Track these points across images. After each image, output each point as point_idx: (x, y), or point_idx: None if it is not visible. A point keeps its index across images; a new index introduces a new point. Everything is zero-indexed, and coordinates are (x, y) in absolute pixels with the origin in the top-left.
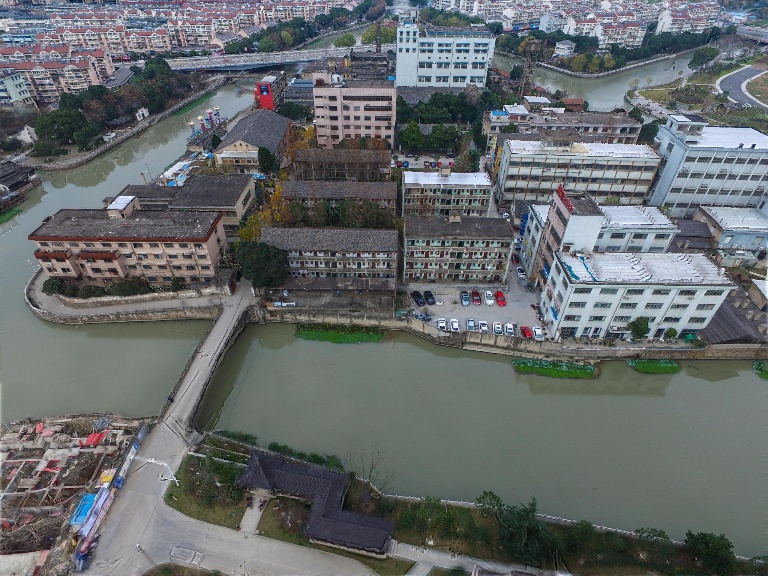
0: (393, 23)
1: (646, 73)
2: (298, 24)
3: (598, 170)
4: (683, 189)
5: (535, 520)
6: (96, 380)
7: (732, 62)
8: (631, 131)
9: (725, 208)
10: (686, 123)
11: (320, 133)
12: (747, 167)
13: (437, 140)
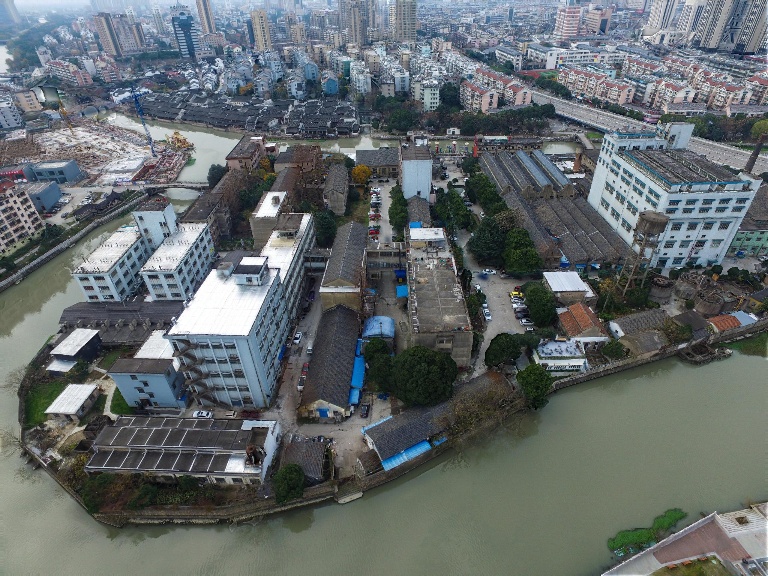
0: None
1: None
2: None
3: None
4: None
5: (50, 232)
6: (193, 178)
7: None
8: None
9: None
10: None
11: None
12: None
13: (390, 216)
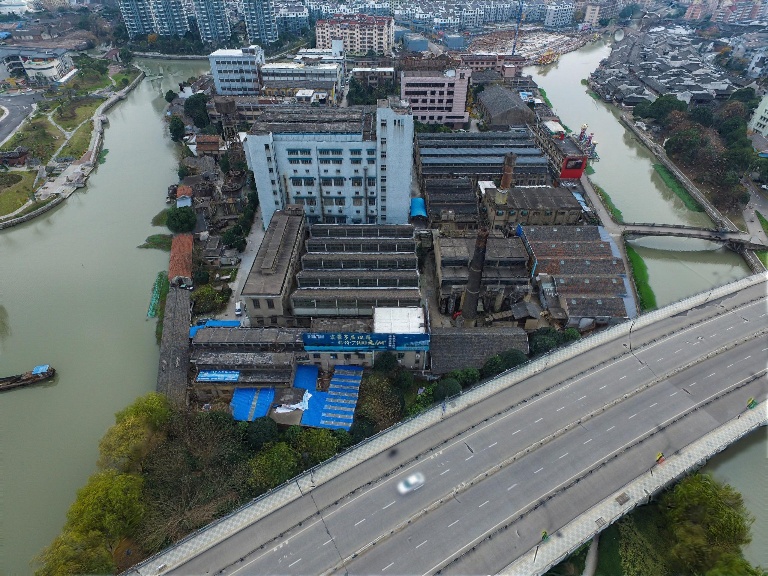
0: None
1: None
2: None
3: None
4: None
5: None
6: None
7: None
8: None
9: None
10: None
11: None
12: None
13: None
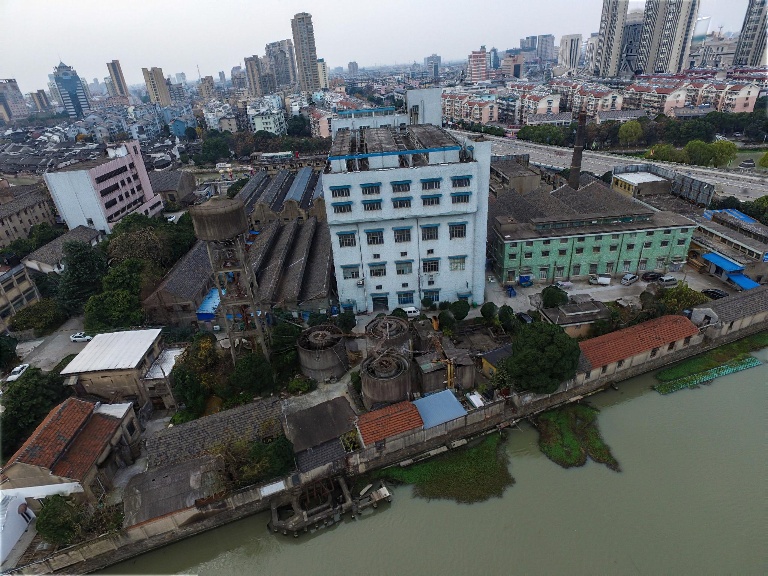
0: None
1: None
2: (763, 118)
3: None
4: None
5: None
6: None
7: None
8: None
9: None
10: None
11: None
12: None
13: None
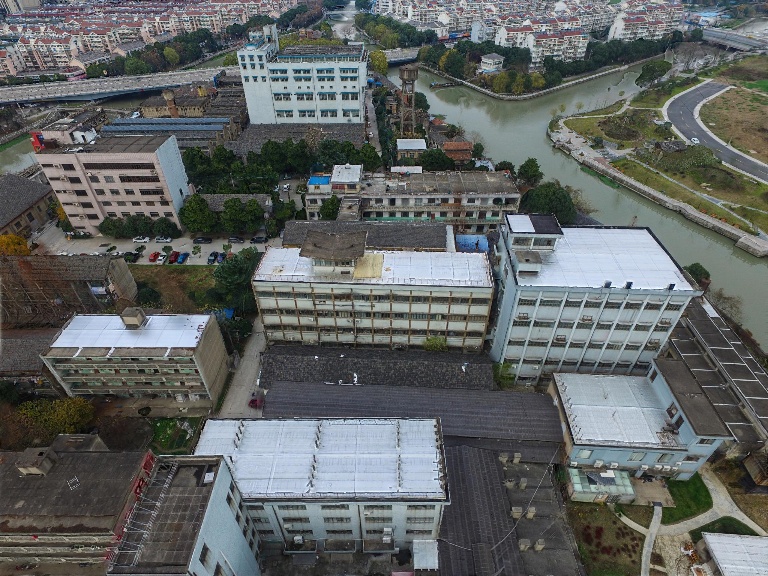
0: (312, 33)
1: (589, 90)
2: (200, 37)
3: (400, 302)
4: (527, 341)
5: None
6: None
7: (690, 75)
8: (509, 201)
9: (594, 377)
10: (525, 235)
11: (70, 212)
12: (625, 313)
13: (228, 222)
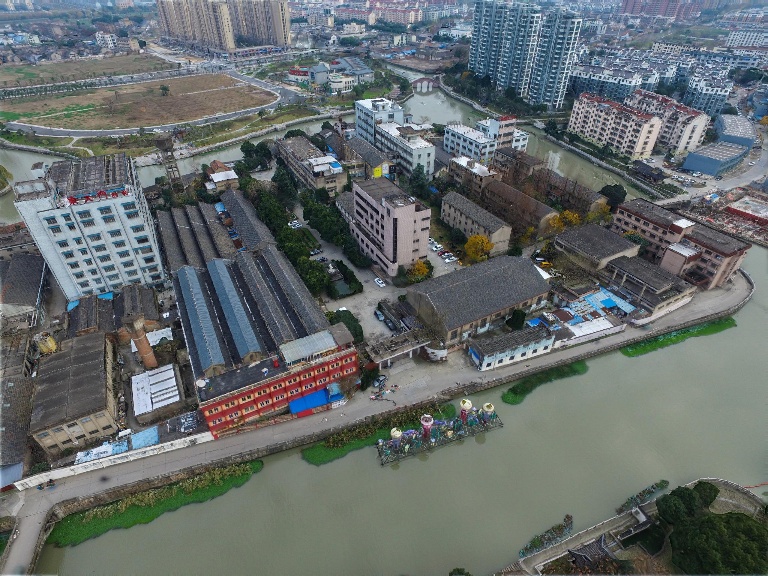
0: None
1: None
2: None
3: None
4: None
5: None
6: None
7: None
8: None
9: None
10: None
11: None
12: None
13: None
